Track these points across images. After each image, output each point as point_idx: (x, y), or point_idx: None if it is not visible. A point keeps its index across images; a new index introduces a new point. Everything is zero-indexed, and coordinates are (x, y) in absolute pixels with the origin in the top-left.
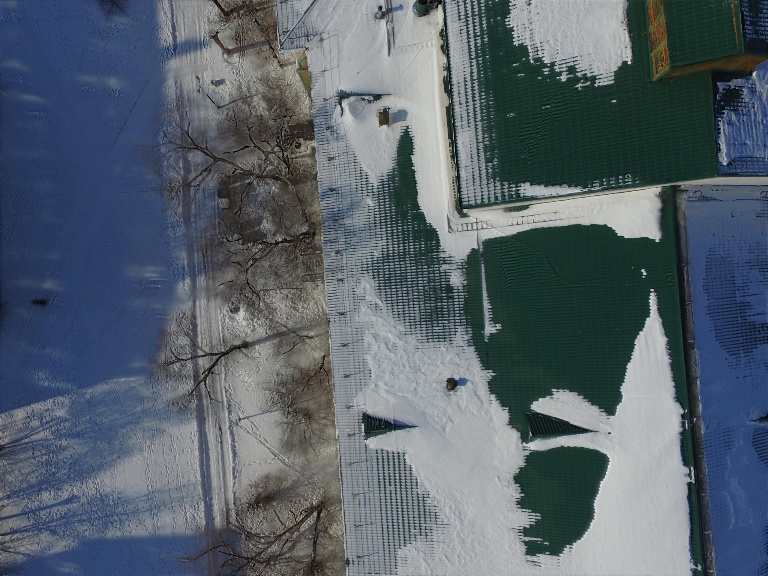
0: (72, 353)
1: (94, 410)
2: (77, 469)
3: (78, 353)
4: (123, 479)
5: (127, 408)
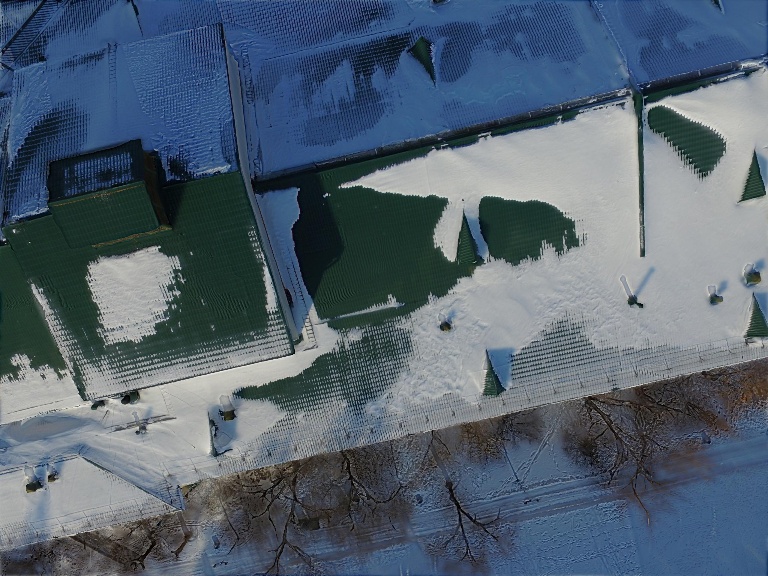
0: None
1: None
2: None
3: None
4: None
5: None
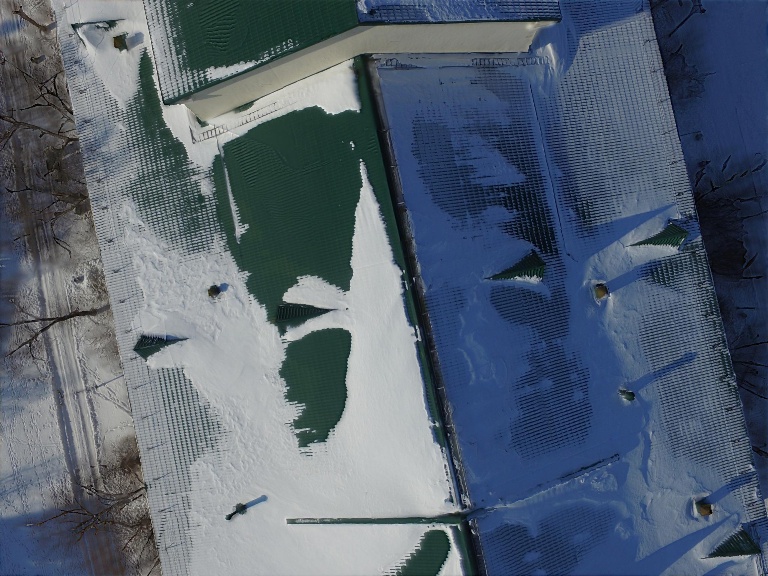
0: None
1: None
2: None
3: None
4: None
5: None
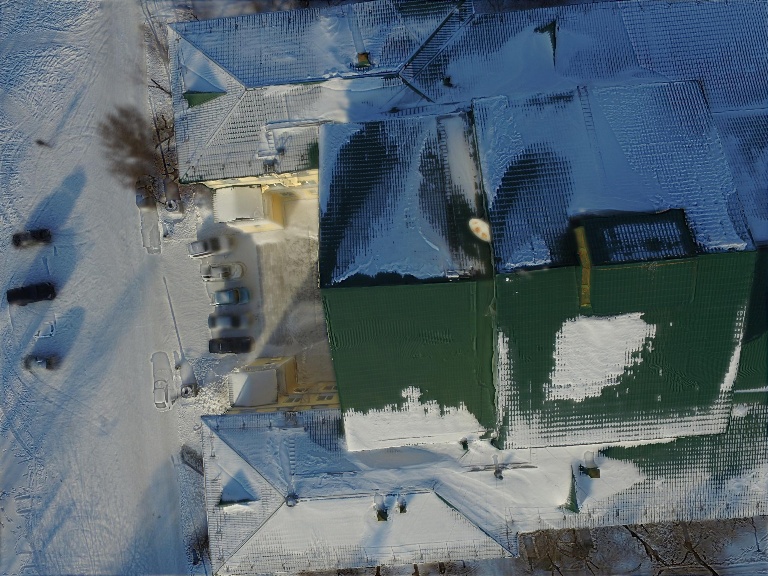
0: None
1: None
2: None
3: None
4: None
5: None
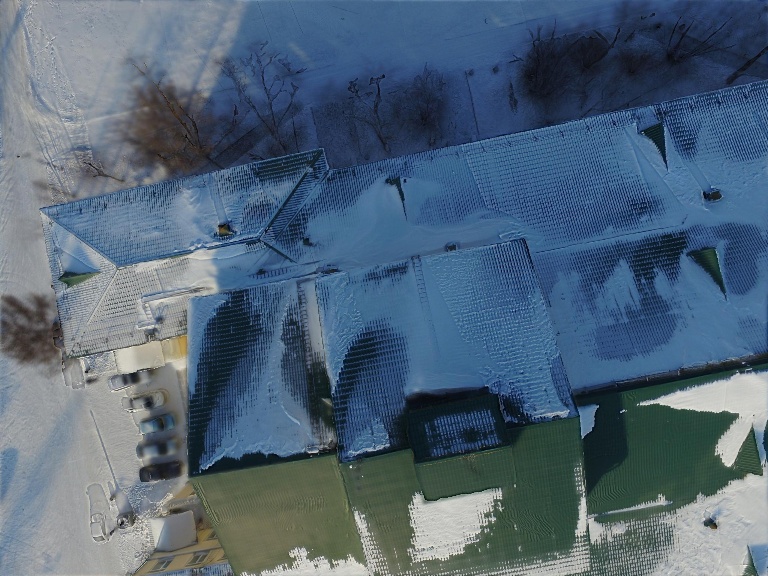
0: None
1: None
2: None
3: None
4: None
5: None
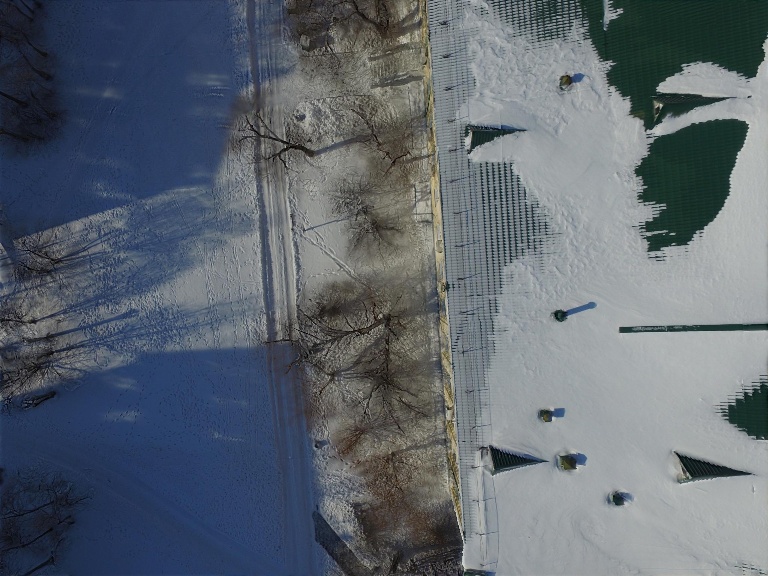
0: (132, 163)
1: (154, 221)
2: (136, 282)
3: (138, 163)
4: (183, 292)
5: (188, 219)
